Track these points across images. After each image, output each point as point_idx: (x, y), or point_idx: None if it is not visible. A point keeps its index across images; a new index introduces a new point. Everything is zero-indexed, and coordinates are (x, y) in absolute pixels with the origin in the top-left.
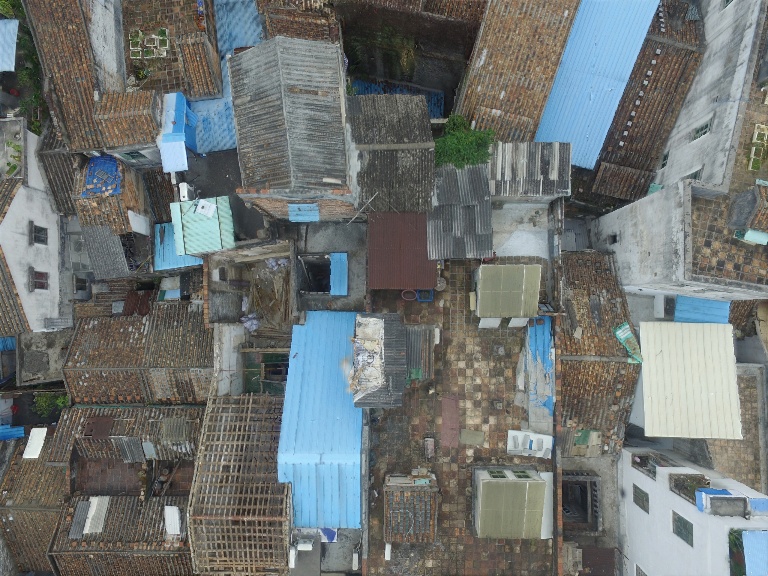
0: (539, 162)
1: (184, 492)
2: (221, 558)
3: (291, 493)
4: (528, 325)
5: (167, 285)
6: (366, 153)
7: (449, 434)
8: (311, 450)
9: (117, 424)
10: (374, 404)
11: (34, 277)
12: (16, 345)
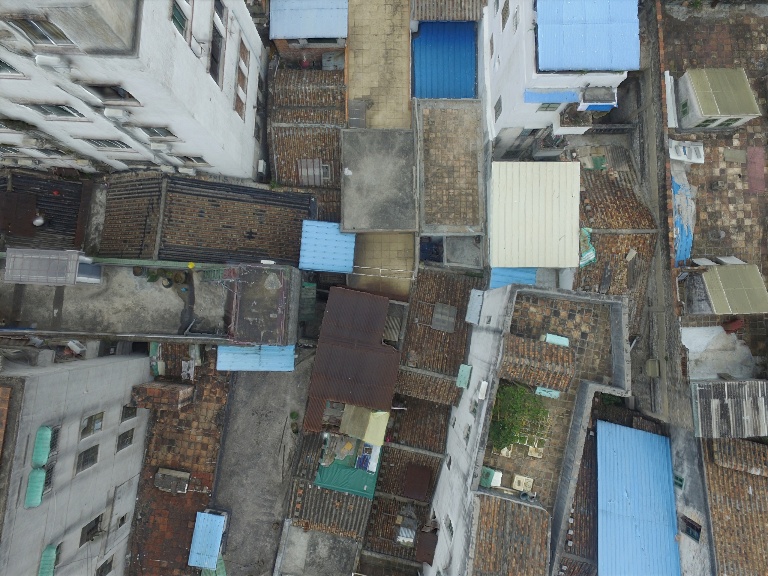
0: (731, 417)
1: None
2: None
3: None
4: (691, 260)
5: None
6: None
7: (757, 158)
8: None
9: None
10: None
11: None
12: None
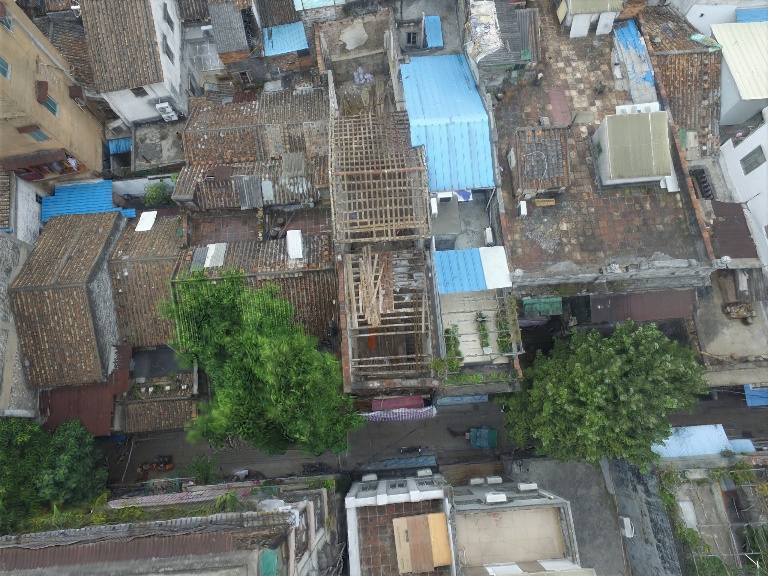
0: None
1: None
2: (362, 220)
3: (425, 154)
4: (614, 29)
5: (270, 87)
6: None
7: (561, 116)
8: (440, 117)
9: (236, 171)
10: (496, 61)
11: (166, 45)
12: (132, 138)
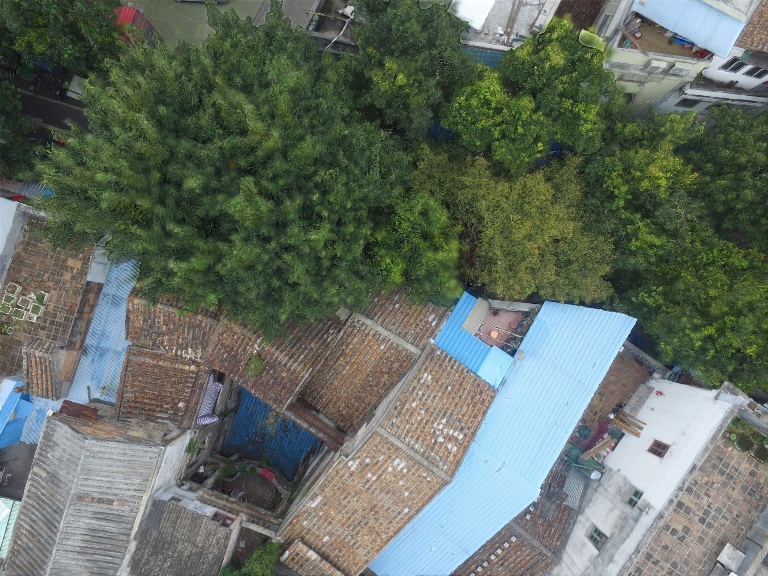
0: None
1: None
2: None
3: None
4: None
5: None
6: None
7: None
8: None
9: None
10: None
11: None
12: None
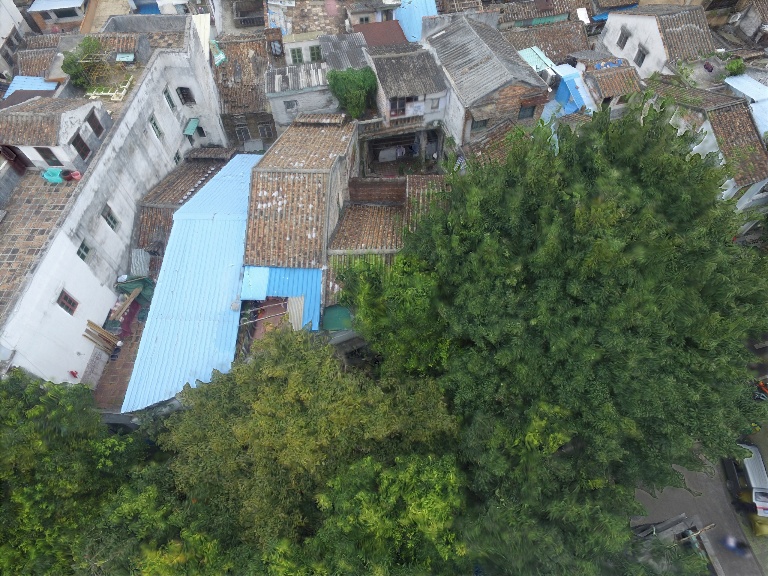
0: (290, 80)
1: (482, 5)
2: None
3: None
4: None
5: None
6: None
7: (331, 3)
8: None
9: (534, 8)
10: None
11: (626, 36)
12: None
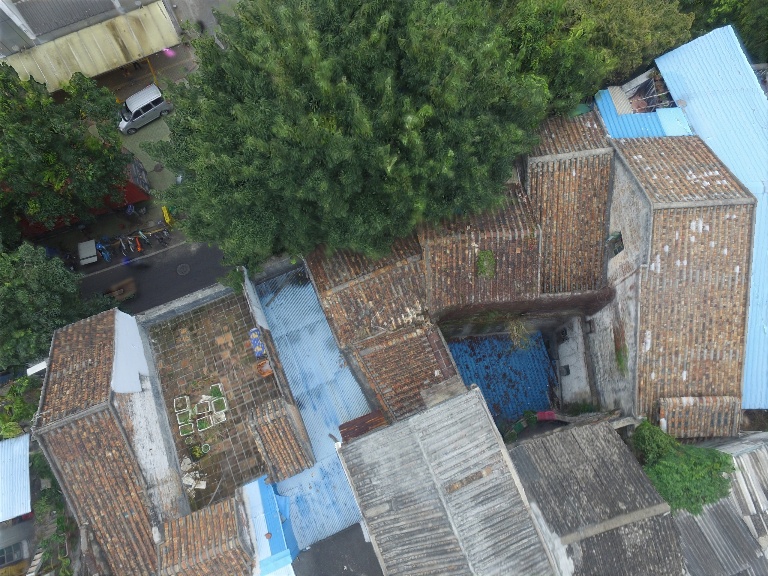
0: None
1: None
2: None
3: None
4: None
5: None
6: (577, 544)
7: None
8: None
9: None
10: None
11: None
12: None
